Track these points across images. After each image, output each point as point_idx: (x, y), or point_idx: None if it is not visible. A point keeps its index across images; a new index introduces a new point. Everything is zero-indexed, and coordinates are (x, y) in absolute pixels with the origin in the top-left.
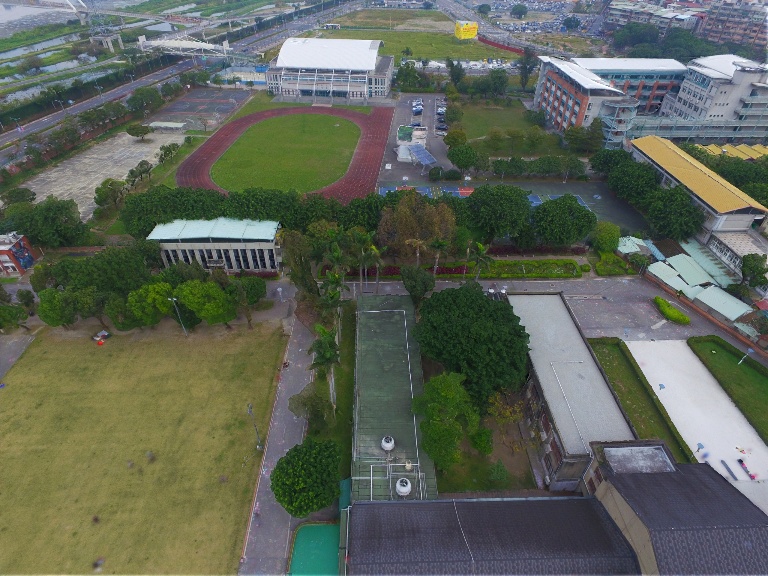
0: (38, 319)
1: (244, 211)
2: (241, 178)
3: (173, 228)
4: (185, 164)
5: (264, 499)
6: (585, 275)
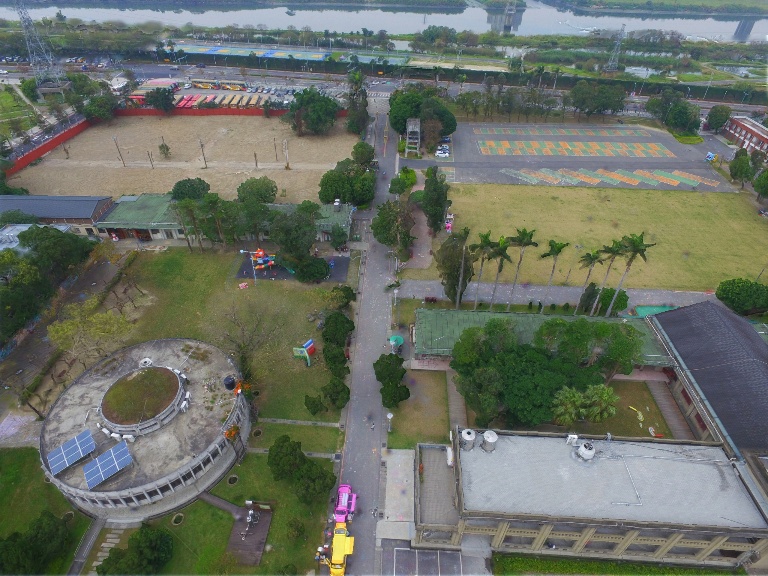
0: (753, 189)
1: None
2: None
3: None
4: None
5: (714, 297)
6: None
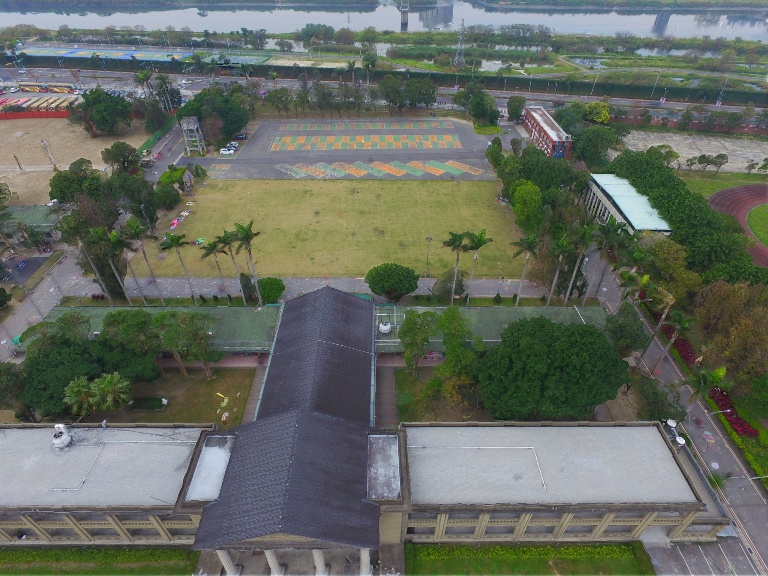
0: None
1: (662, 202)
2: None
3: (613, 180)
4: None
5: None
6: None
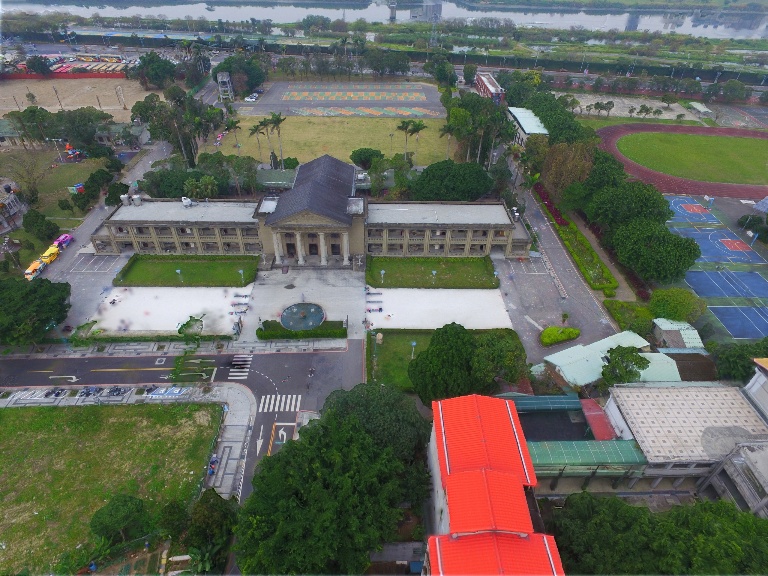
0: None
1: (547, 119)
2: (642, 142)
3: (522, 110)
4: (645, 124)
5: None
6: (599, 294)
